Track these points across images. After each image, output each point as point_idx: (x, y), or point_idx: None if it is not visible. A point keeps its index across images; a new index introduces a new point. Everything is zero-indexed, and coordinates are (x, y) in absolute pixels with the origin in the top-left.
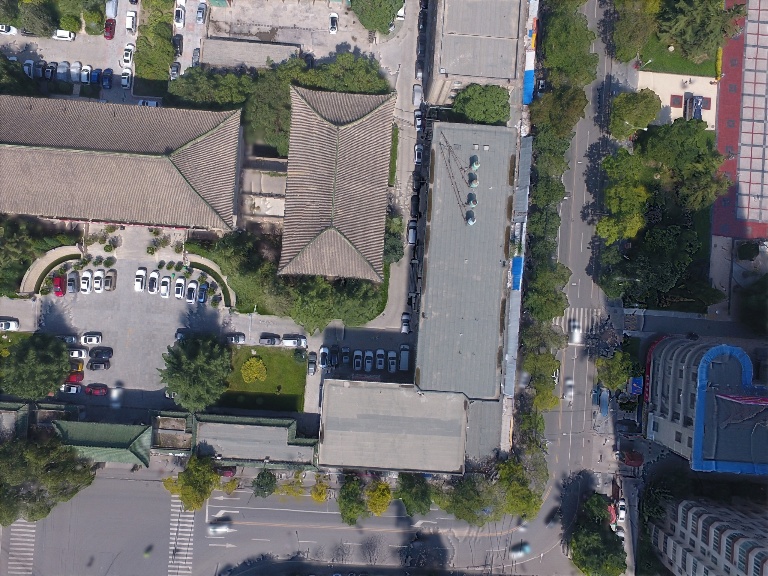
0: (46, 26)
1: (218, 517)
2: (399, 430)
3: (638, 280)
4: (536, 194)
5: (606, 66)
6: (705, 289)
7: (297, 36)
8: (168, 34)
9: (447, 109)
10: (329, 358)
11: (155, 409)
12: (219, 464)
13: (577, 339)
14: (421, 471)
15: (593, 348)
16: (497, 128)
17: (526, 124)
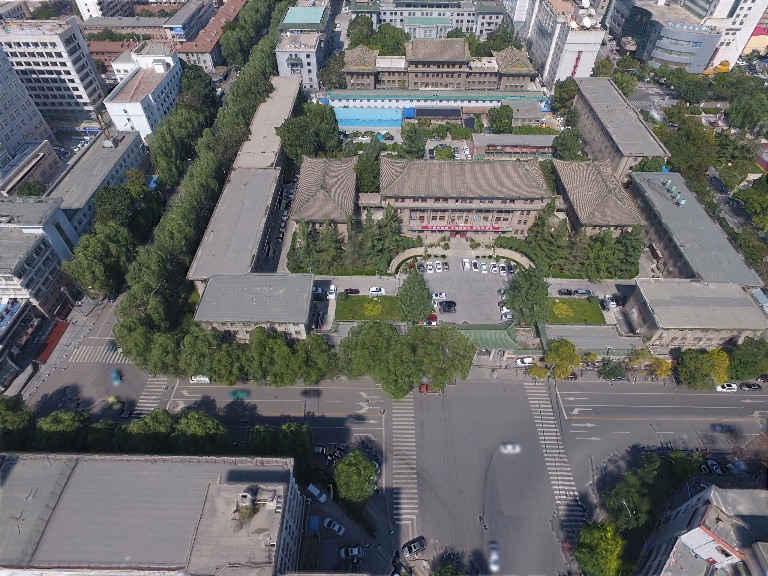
0: None
1: (575, 414)
2: (707, 304)
3: None
4: None
5: None
6: None
7: None
8: None
9: (626, 183)
10: (615, 300)
11: None
12: None
13: None
14: (742, 329)
15: None
16: (668, 173)
17: None
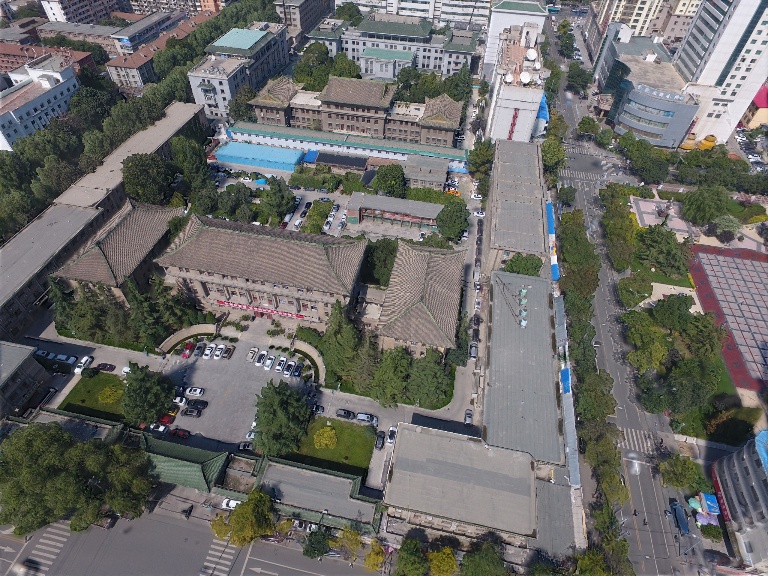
0: (250, 217)
1: None
2: (467, 480)
3: (674, 389)
4: (572, 331)
5: (609, 275)
6: (741, 408)
7: None
8: (319, 229)
9: None
10: None
11: None
12: (275, 510)
13: (635, 456)
14: (491, 528)
15: (654, 467)
16: (536, 278)
17: (557, 291)
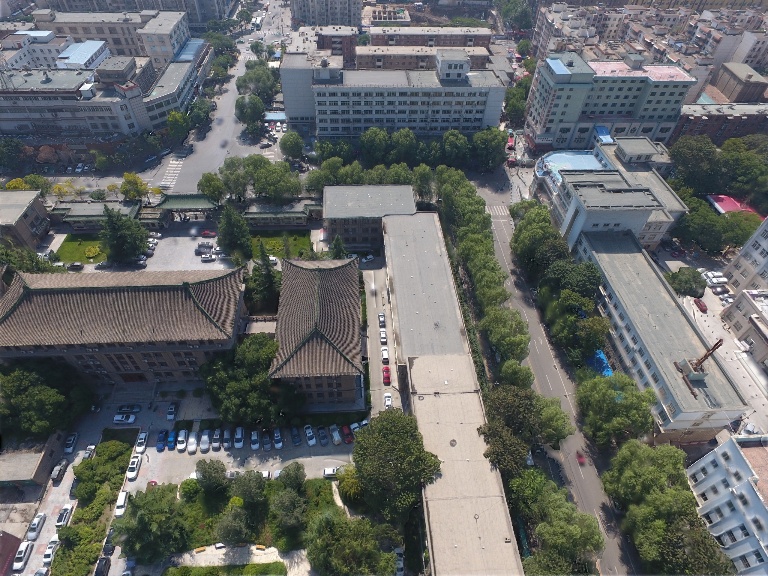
0: None
1: None
2: None
3: None
4: None
5: None
6: None
7: None
8: None
9: None
10: None
11: (172, 229)
12: None
13: None
14: None
15: None
16: None
17: None
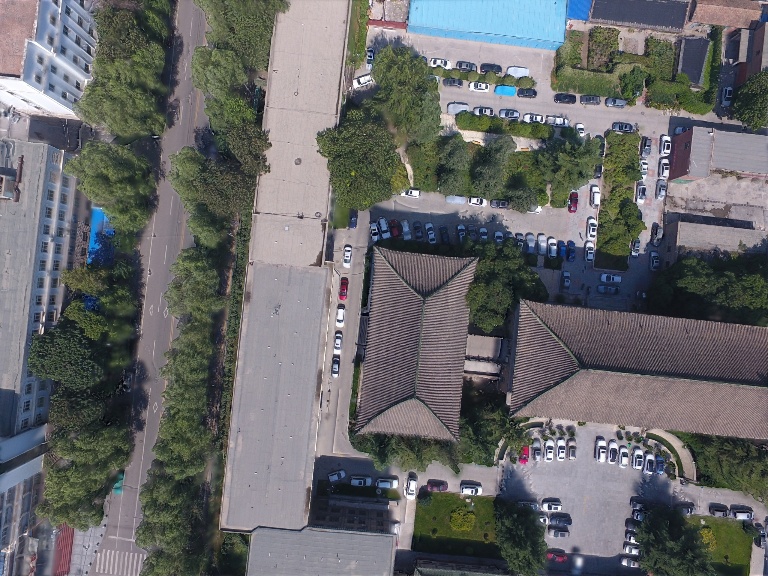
0: None
1: None
2: None
3: None
4: None
5: None
6: None
7: (750, 213)
8: (637, 212)
9: None
10: None
11: (609, 575)
12: None
13: None
14: None
15: None
16: None
17: None
